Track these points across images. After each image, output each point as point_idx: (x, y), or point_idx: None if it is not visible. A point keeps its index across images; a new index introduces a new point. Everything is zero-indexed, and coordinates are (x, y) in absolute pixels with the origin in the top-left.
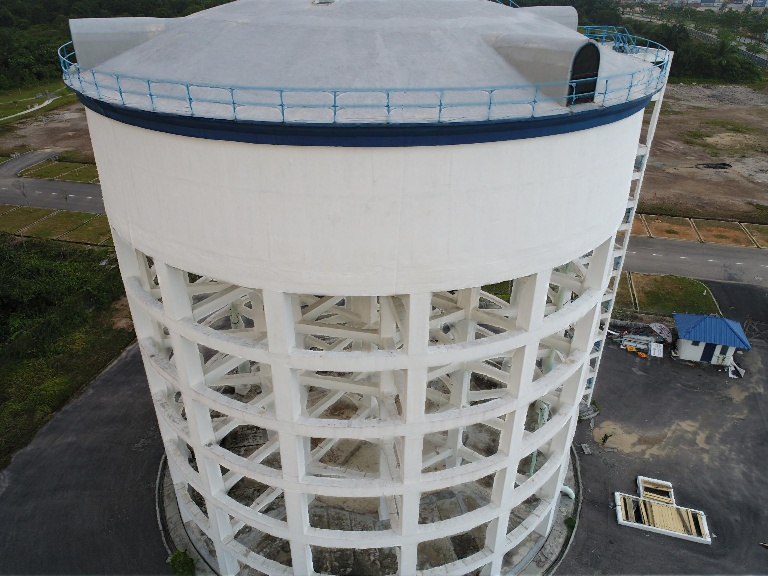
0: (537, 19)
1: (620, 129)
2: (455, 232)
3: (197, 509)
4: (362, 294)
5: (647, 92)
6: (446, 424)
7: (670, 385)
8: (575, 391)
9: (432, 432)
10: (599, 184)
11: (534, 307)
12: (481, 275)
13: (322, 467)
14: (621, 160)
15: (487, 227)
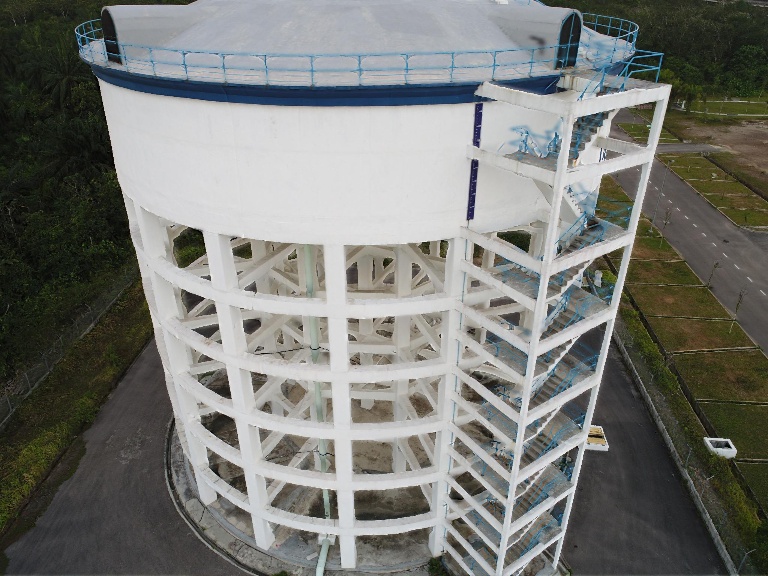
0: (327, 6)
1: (161, 106)
2: None
3: None
4: None
5: (167, 76)
6: None
7: None
8: None
9: None
10: (153, 151)
11: None
12: None
13: (285, 357)
14: (179, 144)
15: None
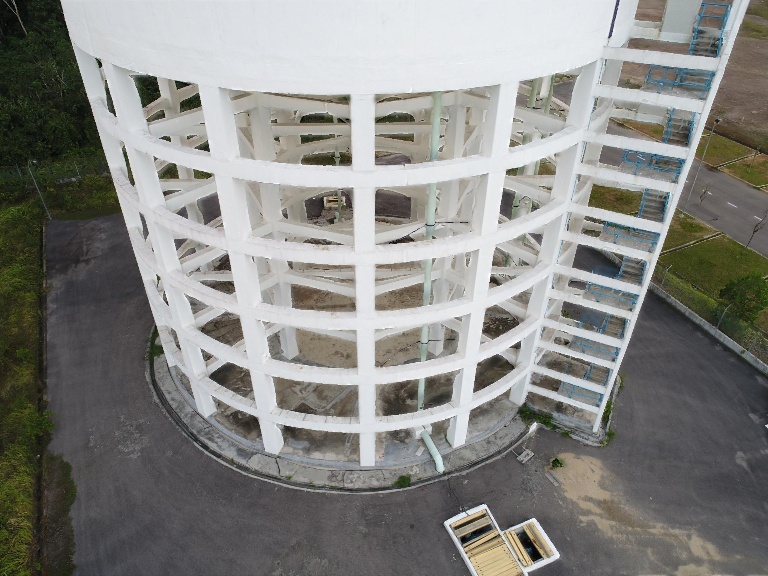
0: None
1: None
2: (108, 0)
3: (179, 254)
4: (82, 48)
5: None
6: (164, 221)
7: (763, 503)
8: (356, 300)
9: (158, 223)
10: None
11: (209, 129)
12: (139, 60)
13: None
14: None
15: (129, 3)
